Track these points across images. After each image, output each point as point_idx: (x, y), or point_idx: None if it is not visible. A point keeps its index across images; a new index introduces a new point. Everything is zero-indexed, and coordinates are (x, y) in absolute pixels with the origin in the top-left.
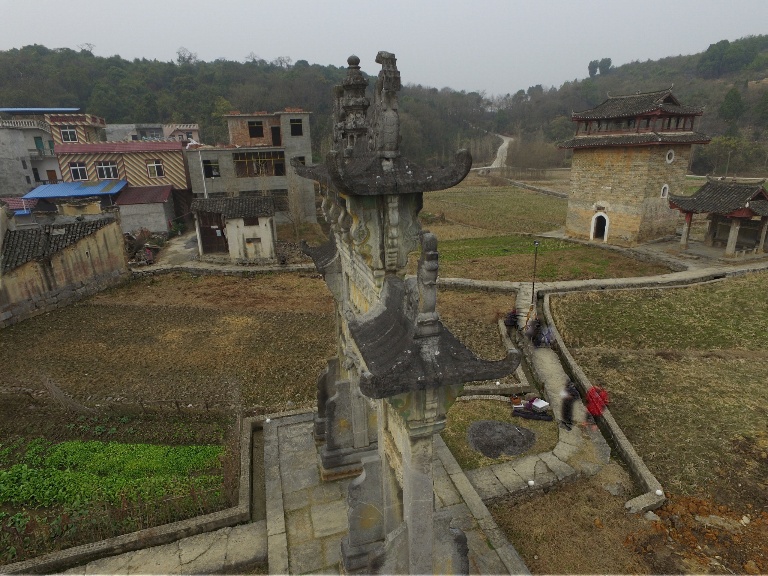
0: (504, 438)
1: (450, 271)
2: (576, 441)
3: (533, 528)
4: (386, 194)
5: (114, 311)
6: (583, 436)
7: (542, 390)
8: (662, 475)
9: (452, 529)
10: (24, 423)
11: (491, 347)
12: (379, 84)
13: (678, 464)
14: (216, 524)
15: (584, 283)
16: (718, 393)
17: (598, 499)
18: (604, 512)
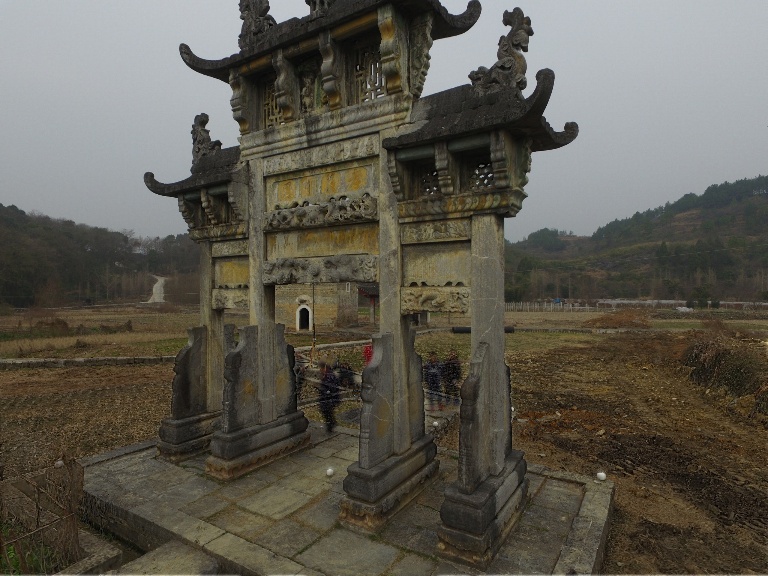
0: None
1: None
2: (432, 403)
3: None
4: (432, 7)
5: None
6: (432, 400)
7: None
8: None
9: None
10: None
11: None
12: None
13: None
14: None
15: (324, 345)
16: None
17: None
18: None
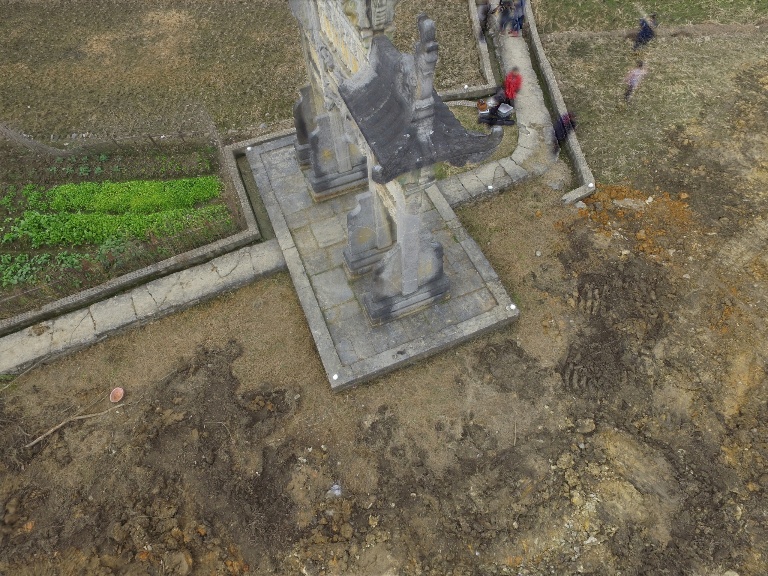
0: None
1: None
2: (532, 144)
3: (488, 222)
4: None
5: (5, 12)
6: (539, 139)
7: (508, 90)
8: (597, 168)
9: (432, 243)
10: (2, 170)
11: (460, 38)
12: None
13: (613, 157)
14: (235, 245)
15: None
16: (671, 80)
17: (542, 194)
18: (545, 204)
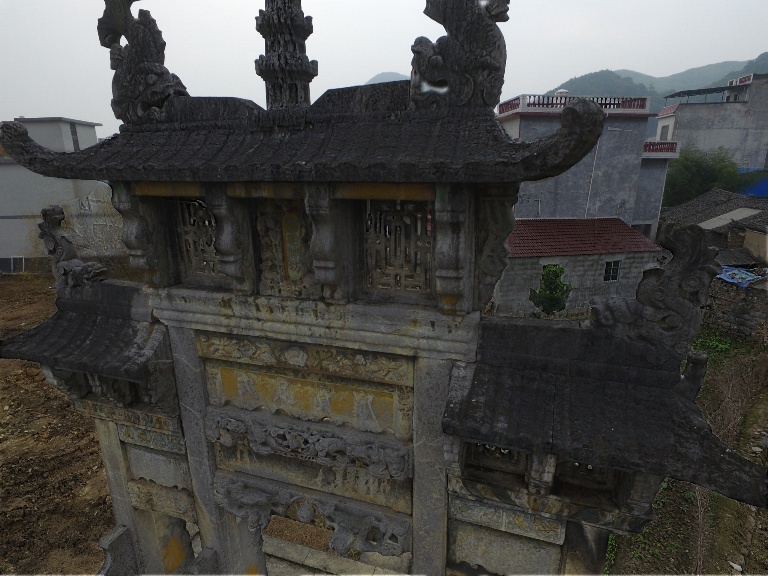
0: None
1: None
2: None
3: None
4: None
5: None
6: None
7: None
8: None
9: (106, 571)
10: None
11: None
12: None
13: None
14: None
15: None
16: None
17: None
18: None
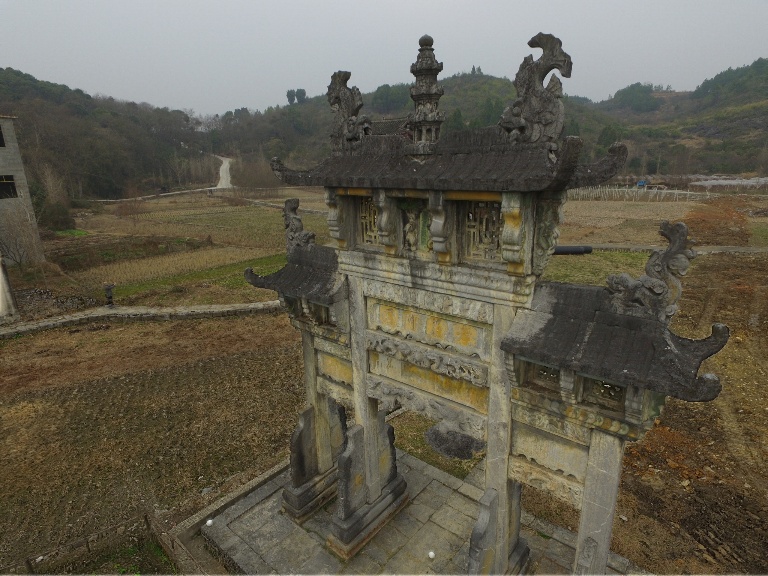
0: (466, 436)
1: (261, 294)
2: None
3: (547, 505)
4: None
5: None
6: None
7: None
8: None
9: None
10: None
11: None
12: (543, 68)
13: None
14: None
15: None
16: None
17: None
18: None
